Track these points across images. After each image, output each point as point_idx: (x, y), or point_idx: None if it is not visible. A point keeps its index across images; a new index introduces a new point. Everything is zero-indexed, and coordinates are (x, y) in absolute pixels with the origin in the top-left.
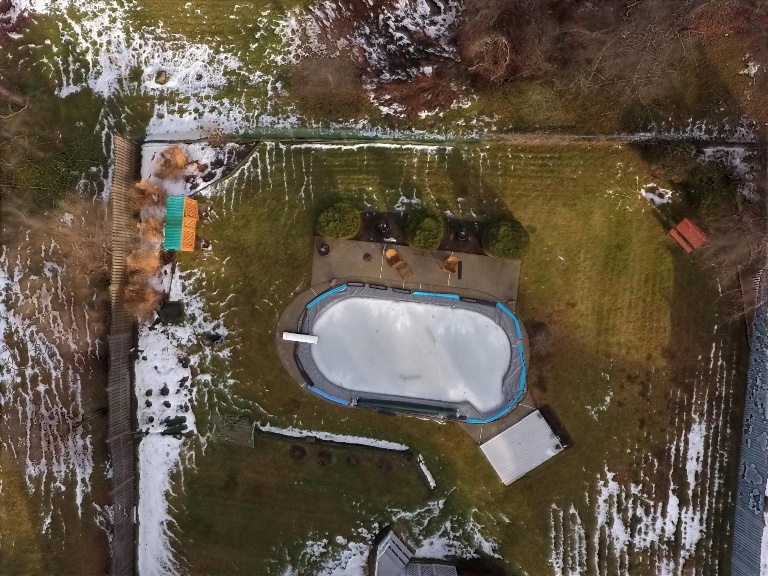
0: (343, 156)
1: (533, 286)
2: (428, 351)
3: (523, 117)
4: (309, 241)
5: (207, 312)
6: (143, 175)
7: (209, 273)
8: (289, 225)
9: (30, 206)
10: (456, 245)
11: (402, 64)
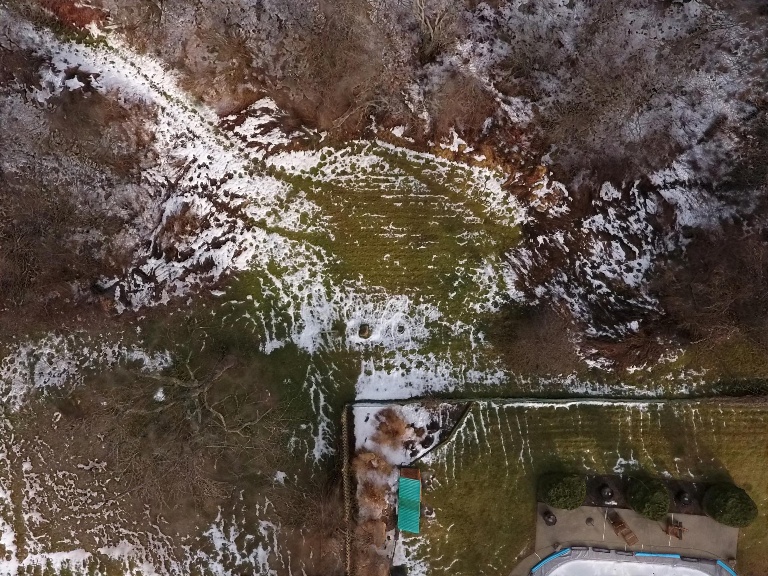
0: (557, 416)
1: (751, 542)
2: None
3: (731, 370)
4: (532, 507)
5: None
6: (357, 437)
7: (434, 540)
8: (511, 491)
9: (243, 466)
10: (676, 506)
11: (609, 320)
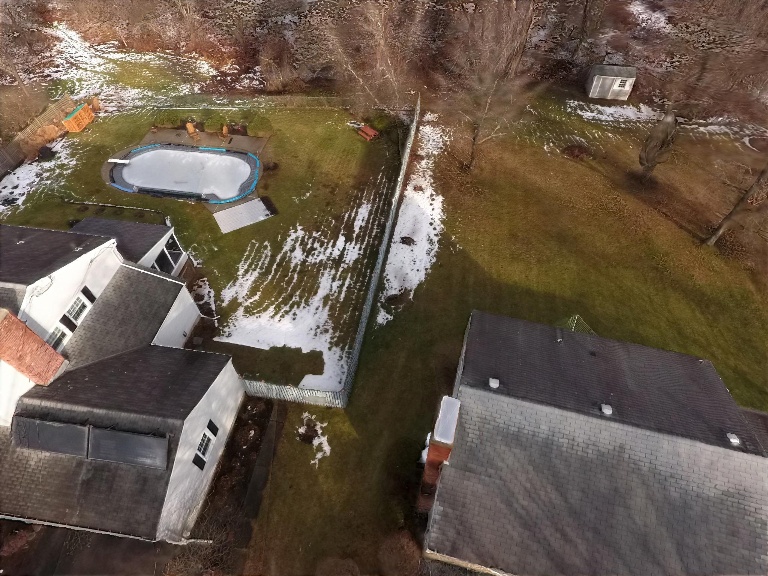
0: None
1: (273, 149)
2: (197, 172)
3: None
4: None
5: (69, 155)
6: None
7: (82, 140)
8: (140, 125)
9: None
10: (232, 132)
11: None
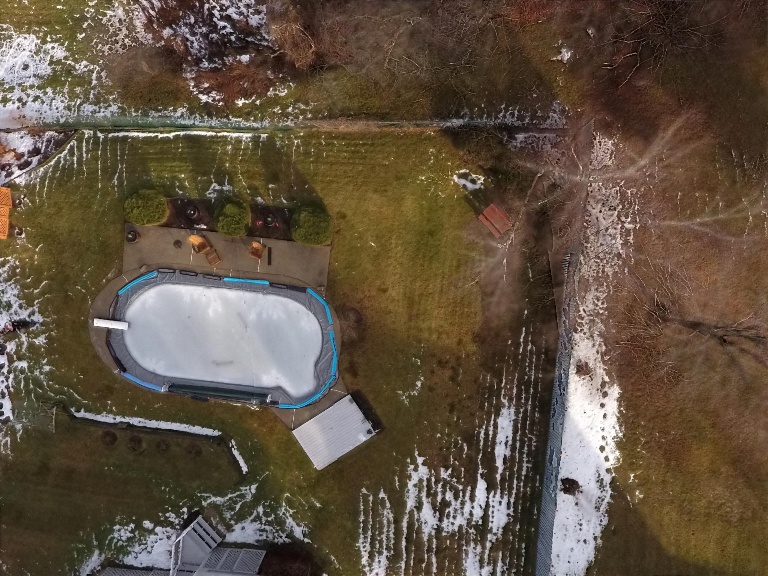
0: (158, 144)
1: (344, 272)
2: (240, 337)
3: (338, 104)
4: (120, 228)
5: (22, 299)
6: None
7: (22, 260)
8: (101, 212)
9: None
10: (266, 231)
11: (219, 52)
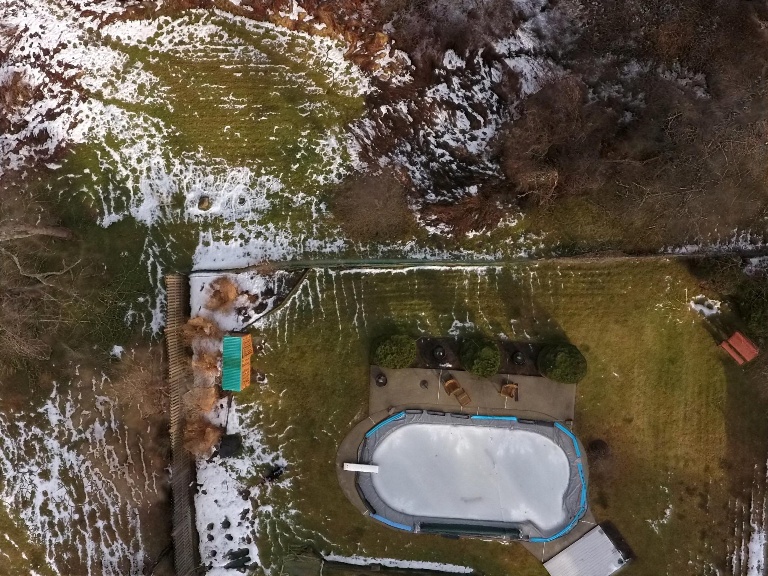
0: (393, 281)
1: (589, 404)
2: (488, 473)
3: (570, 233)
4: (365, 370)
5: (265, 444)
6: (193, 306)
7: (266, 406)
8: (344, 355)
9: (78, 341)
10: (512, 368)
11: (447, 184)
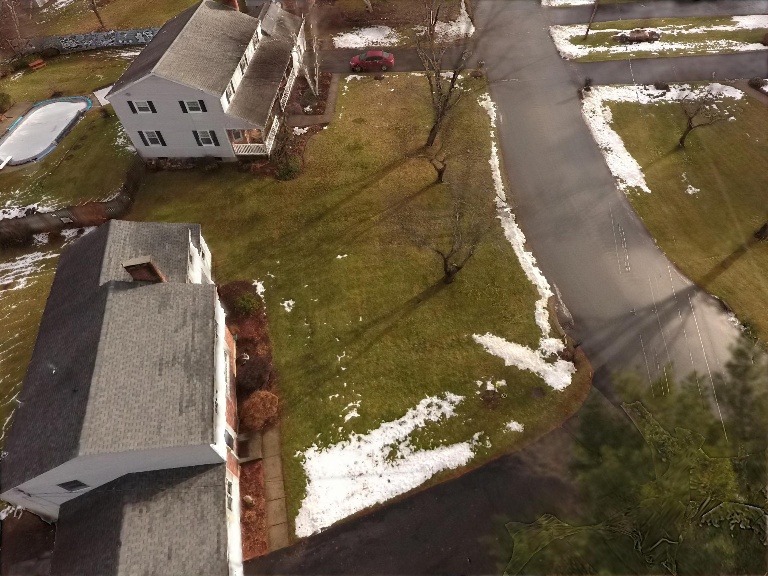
0: None
1: None
2: None
3: None
4: None
5: None
6: None
7: None
8: None
9: None
10: None
11: None
